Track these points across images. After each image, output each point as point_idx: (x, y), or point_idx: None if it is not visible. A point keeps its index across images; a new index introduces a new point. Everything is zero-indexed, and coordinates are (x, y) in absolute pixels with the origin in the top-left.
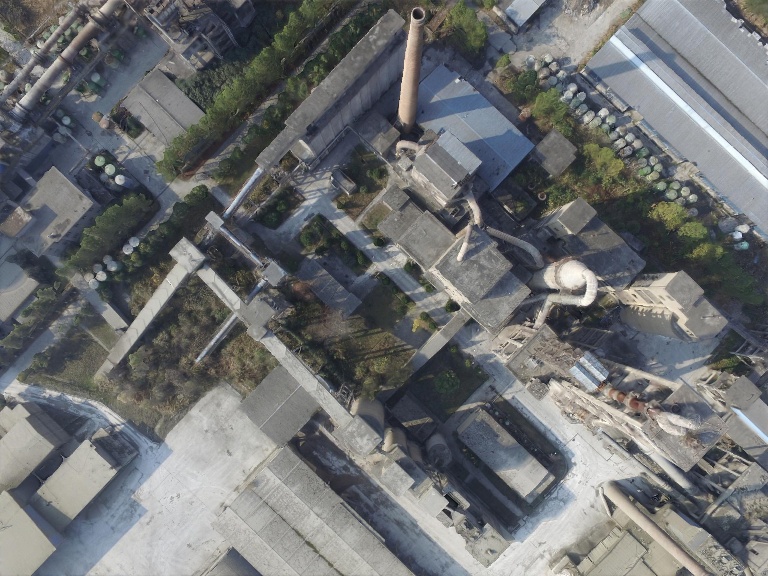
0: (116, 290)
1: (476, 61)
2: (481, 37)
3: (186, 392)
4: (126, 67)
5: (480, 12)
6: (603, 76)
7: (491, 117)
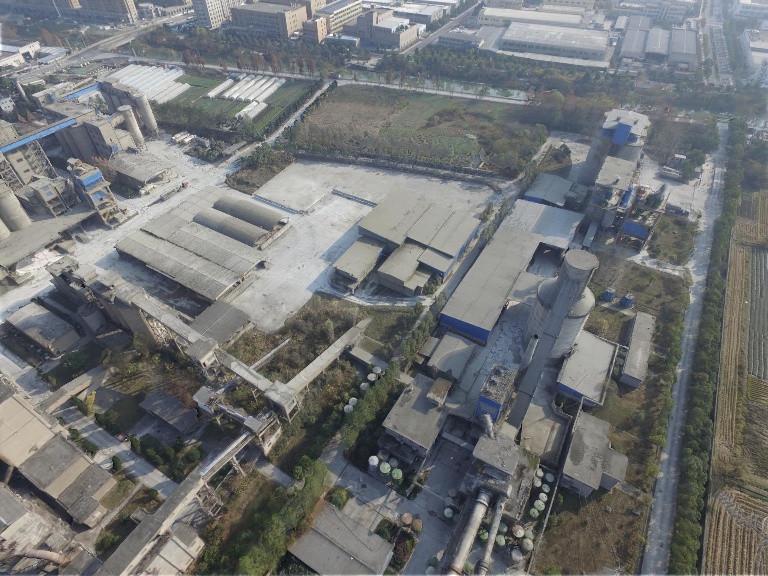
0: None
1: None
2: None
3: None
4: None
5: None
6: None
7: None
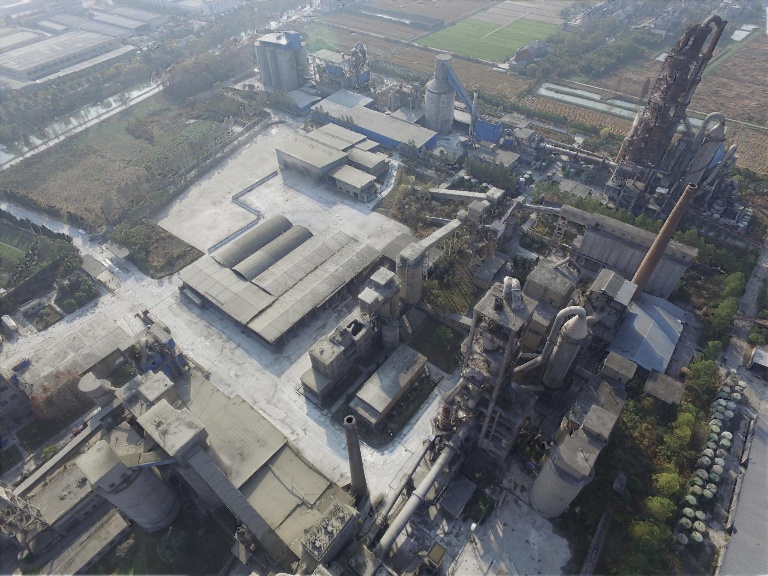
0: (458, 189)
1: (704, 342)
2: (721, 320)
3: (408, 212)
4: (585, 184)
5: (745, 343)
6: (759, 427)
7: (666, 344)
